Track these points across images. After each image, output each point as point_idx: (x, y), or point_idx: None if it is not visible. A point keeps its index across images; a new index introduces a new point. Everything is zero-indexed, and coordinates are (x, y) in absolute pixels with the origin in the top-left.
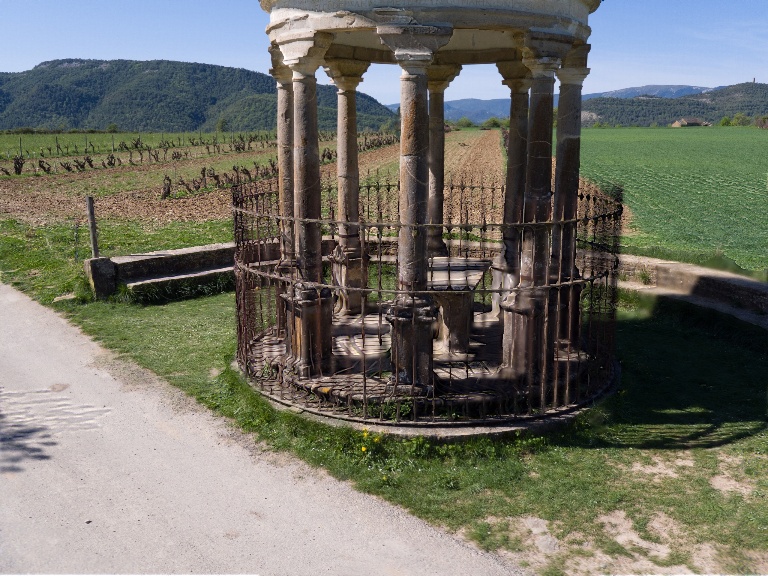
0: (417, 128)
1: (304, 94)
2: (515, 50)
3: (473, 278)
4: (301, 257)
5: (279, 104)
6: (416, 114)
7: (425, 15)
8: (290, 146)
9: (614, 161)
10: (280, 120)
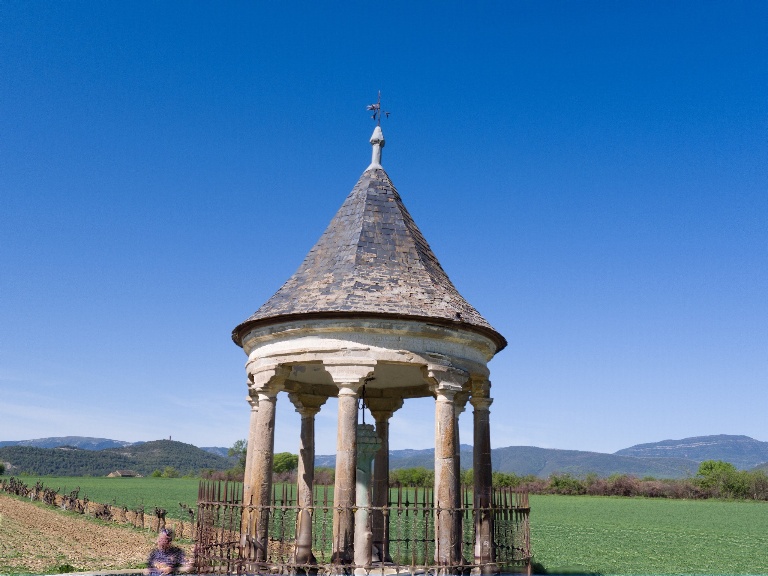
0: (454, 438)
1: (355, 407)
2: (382, 390)
3: (420, 569)
4: (346, 552)
5: (263, 414)
6: (453, 428)
7: (457, 362)
8: (271, 453)
9: (161, 504)
10: (263, 428)
